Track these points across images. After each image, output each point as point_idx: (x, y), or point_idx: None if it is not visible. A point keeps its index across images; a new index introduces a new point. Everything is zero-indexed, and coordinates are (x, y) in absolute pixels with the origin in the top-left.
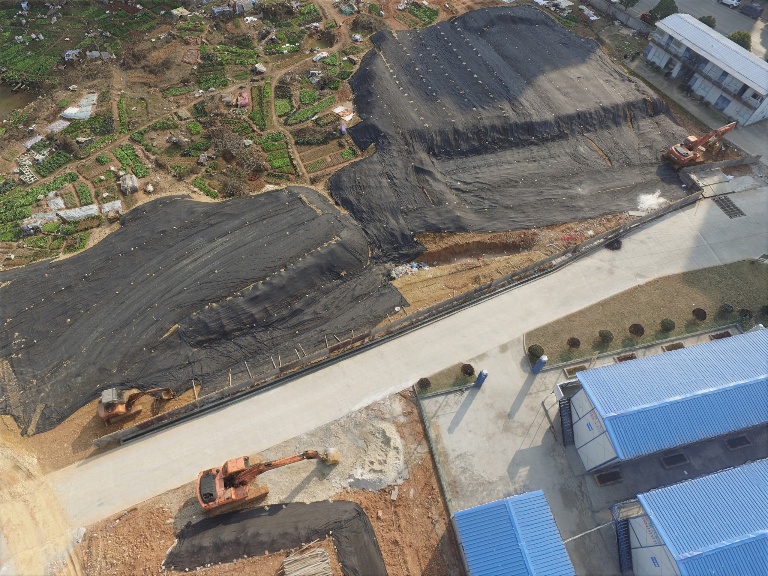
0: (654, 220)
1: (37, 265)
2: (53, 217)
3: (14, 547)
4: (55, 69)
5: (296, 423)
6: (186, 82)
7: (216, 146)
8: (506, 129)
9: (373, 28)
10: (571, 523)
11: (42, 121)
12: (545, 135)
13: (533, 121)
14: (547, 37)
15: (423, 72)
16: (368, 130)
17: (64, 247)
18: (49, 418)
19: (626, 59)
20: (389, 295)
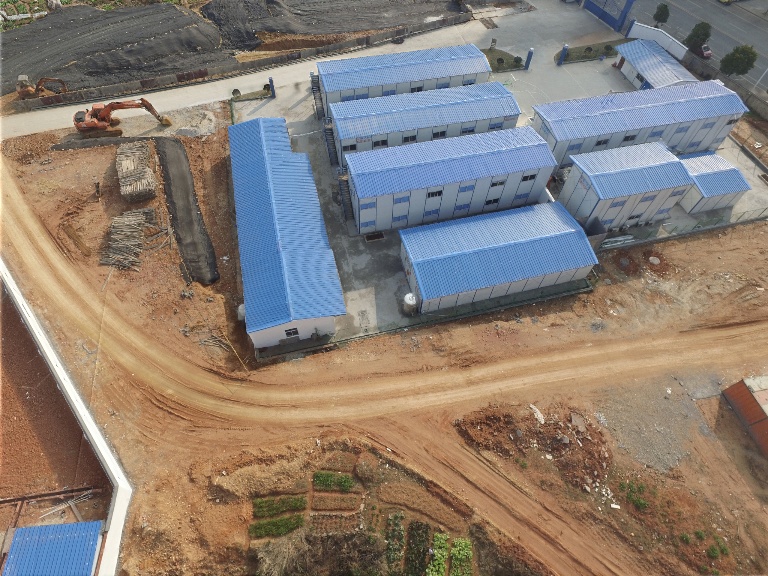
0: (432, 30)
1: None
2: None
3: None
4: None
5: None
6: None
7: None
8: None
9: None
10: (310, 149)
11: None
12: None
13: None
14: None
15: None
16: None
17: None
18: None
19: None
20: (229, 61)
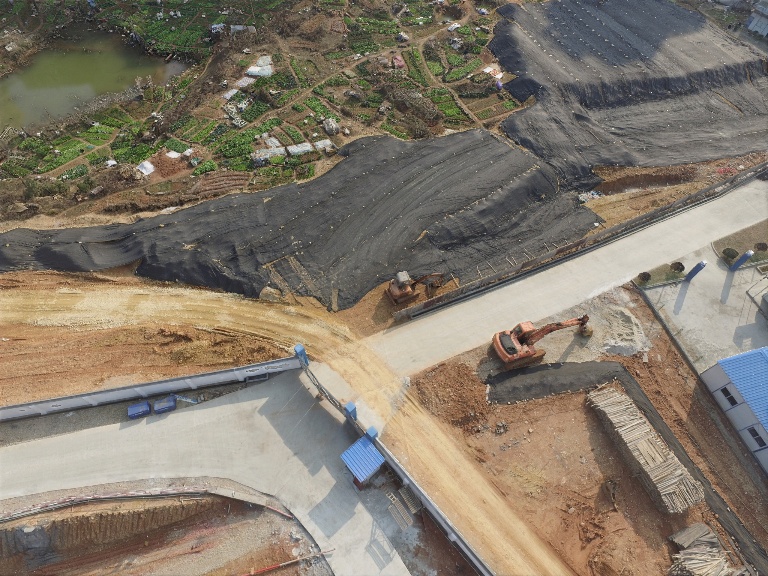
0: None
1: (287, 186)
2: (276, 152)
3: (358, 389)
4: (201, 41)
5: (546, 306)
6: (342, 48)
7: (394, 97)
8: (646, 84)
9: (496, 3)
10: None
11: (230, 78)
12: (679, 90)
13: (669, 77)
14: (658, 10)
15: (559, 37)
16: (526, 84)
17: (296, 175)
18: (346, 299)
19: (730, 29)
20: (585, 214)
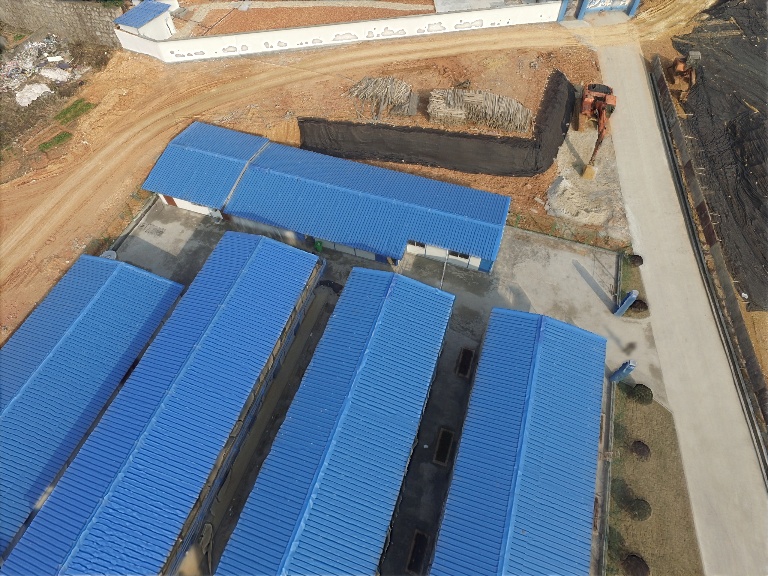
0: None
1: None
2: None
3: (598, 28)
4: None
5: (628, 164)
6: None
7: None
8: None
9: None
10: None
11: None
12: None
13: None
14: None
15: None
16: None
17: None
18: (683, 46)
19: None
20: None
